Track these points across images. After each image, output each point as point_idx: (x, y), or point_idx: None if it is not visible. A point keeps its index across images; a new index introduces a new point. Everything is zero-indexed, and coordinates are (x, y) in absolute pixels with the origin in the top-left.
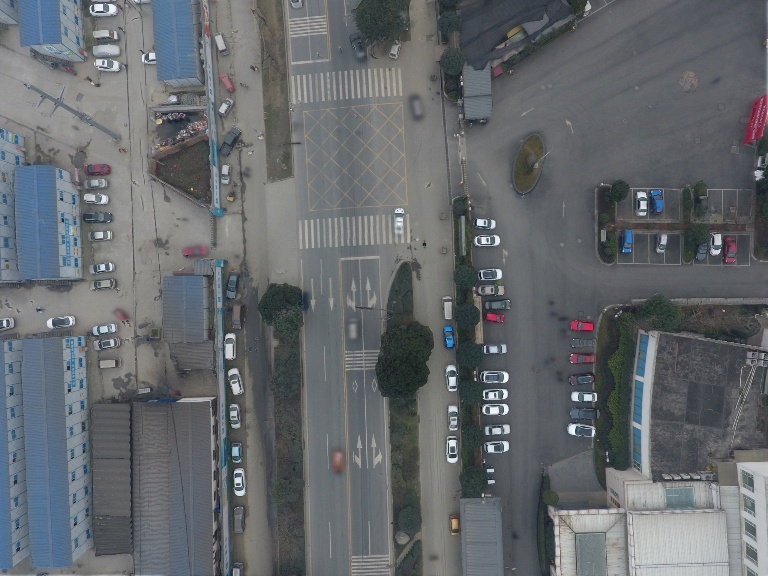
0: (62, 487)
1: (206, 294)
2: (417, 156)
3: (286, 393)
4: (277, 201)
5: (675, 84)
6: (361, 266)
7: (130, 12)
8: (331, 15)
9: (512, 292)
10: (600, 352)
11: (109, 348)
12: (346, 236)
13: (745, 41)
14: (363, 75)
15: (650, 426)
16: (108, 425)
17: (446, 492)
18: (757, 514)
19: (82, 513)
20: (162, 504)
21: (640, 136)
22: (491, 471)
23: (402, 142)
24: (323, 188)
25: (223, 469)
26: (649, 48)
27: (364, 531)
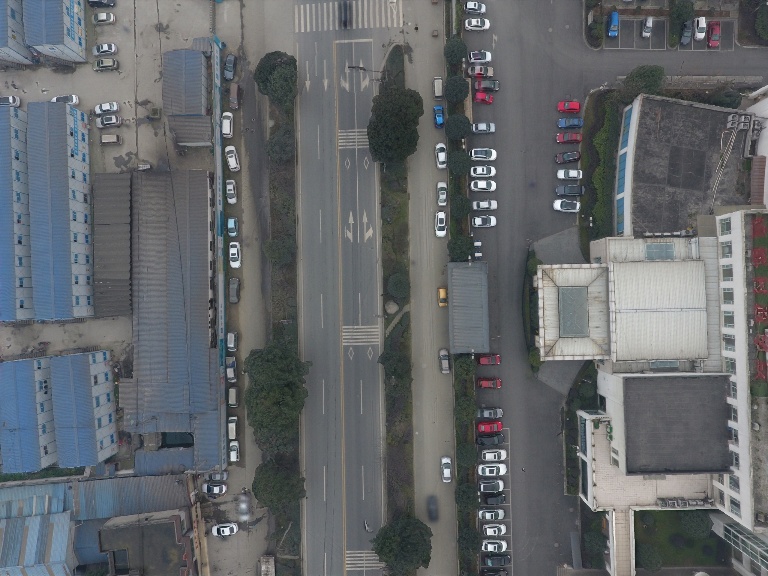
0: (64, 243)
1: (205, 73)
2: None
3: (280, 154)
4: None
5: None
6: (355, 48)
7: None
8: None
9: (501, 75)
10: (586, 133)
11: (111, 124)
12: (340, 20)
13: None
14: None
15: (632, 185)
16: (109, 193)
17: (435, 267)
18: (734, 252)
19: (83, 277)
20: (160, 268)
21: None
22: (478, 244)
23: None
24: None
25: (219, 238)
26: None
27: (355, 302)
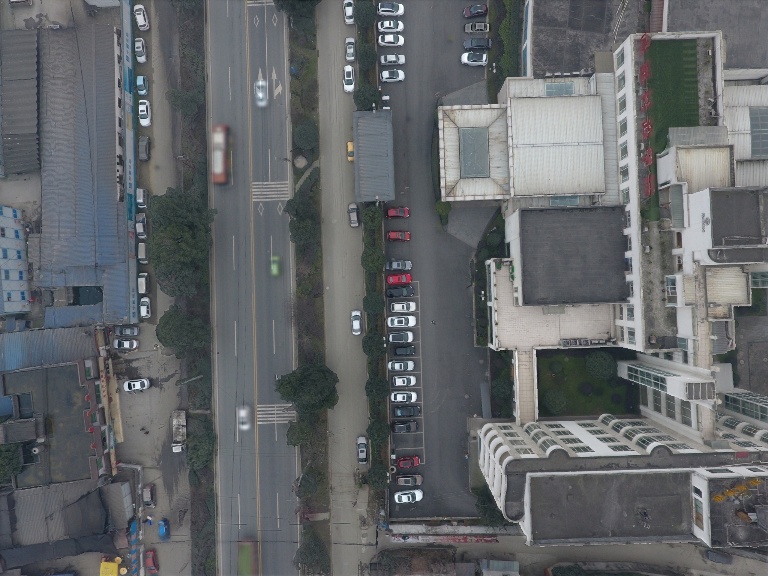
0: None
1: None
2: None
3: (183, 2)
4: None
5: None
6: None
7: None
8: None
9: None
10: None
11: None
12: None
13: None
14: None
15: None
16: (16, 49)
17: (344, 123)
18: (626, 80)
19: None
20: (67, 123)
21: None
22: (386, 98)
23: None
24: None
25: (127, 93)
26: None
27: (264, 158)
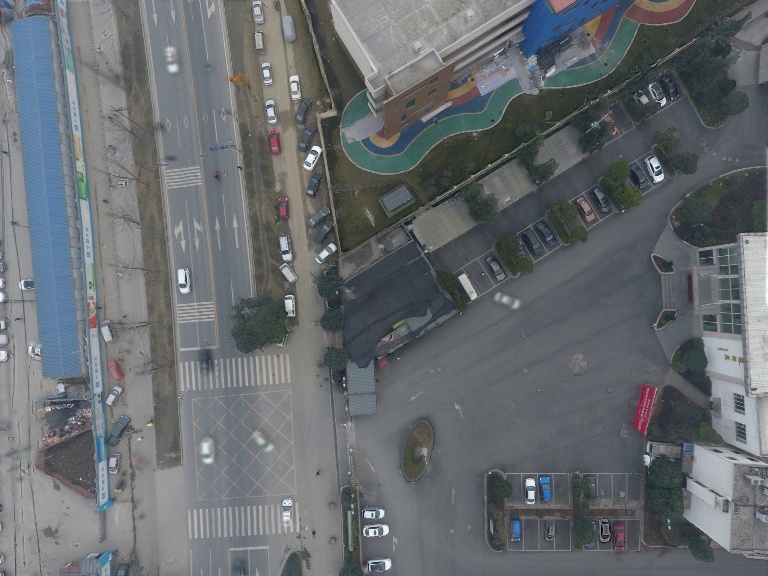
0: None
1: None
2: (306, 443)
3: None
4: (166, 489)
5: (564, 366)
6: (250, 557)
7: (15, 306)
8: (218, 302)
9: None
10: None
11: None
12: (235, 526)
13: (634, 322)
14: (251, 363)
15: None
16: None
17: None
18: None
19: None
20: None
21: (529, 420)
22: None
23: (290, 430)
24: (212, 477)
25: None
26: (538, 330)
27: None
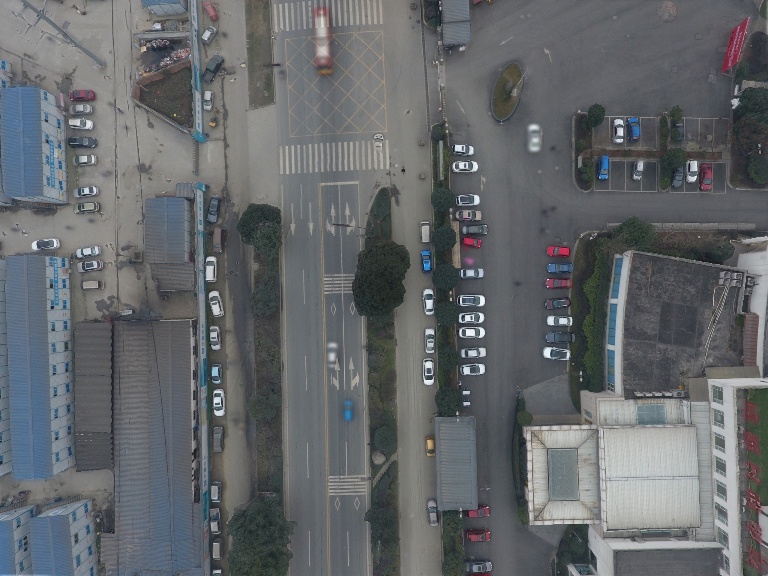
0: (44, 400)
1: (188, 217)
2: (397, 83)
3: (264, 310)
4: (258, 128)
5: (653, 14)
6: (340, 191)
7: None
8: None
9: (489, 218)
10: (576, 277)
11: (92, 270)
12: (326, 162)
13: None
14: (344, 3)
15: (623, 344)
16: (90, 343)
17: (422, 414)
18: (726, 425)
19: (64, 429)
20: (142, 421)
21: (618, 65)
22: (467, 393)
23: (382, 70)
24: (304, 114)
25: (203, 388)
26: None
27: (341, 451)
